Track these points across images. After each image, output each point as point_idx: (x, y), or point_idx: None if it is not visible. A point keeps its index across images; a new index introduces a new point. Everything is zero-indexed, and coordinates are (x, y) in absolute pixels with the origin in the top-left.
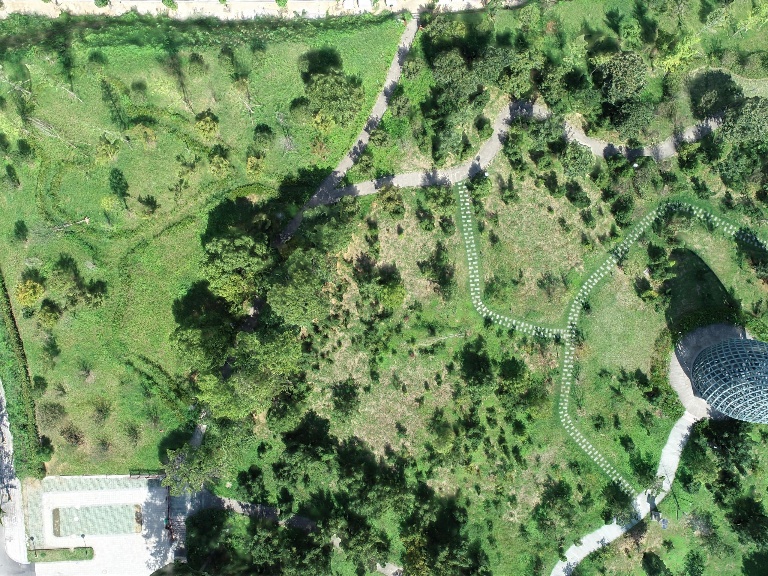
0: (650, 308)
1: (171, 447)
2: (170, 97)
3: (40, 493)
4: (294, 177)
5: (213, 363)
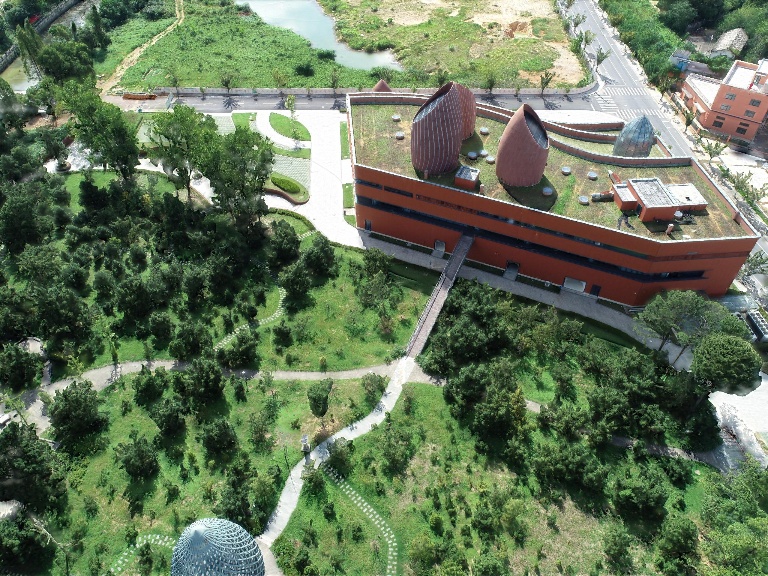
0: None
1: None
2: None
3: None
4: None
5: None
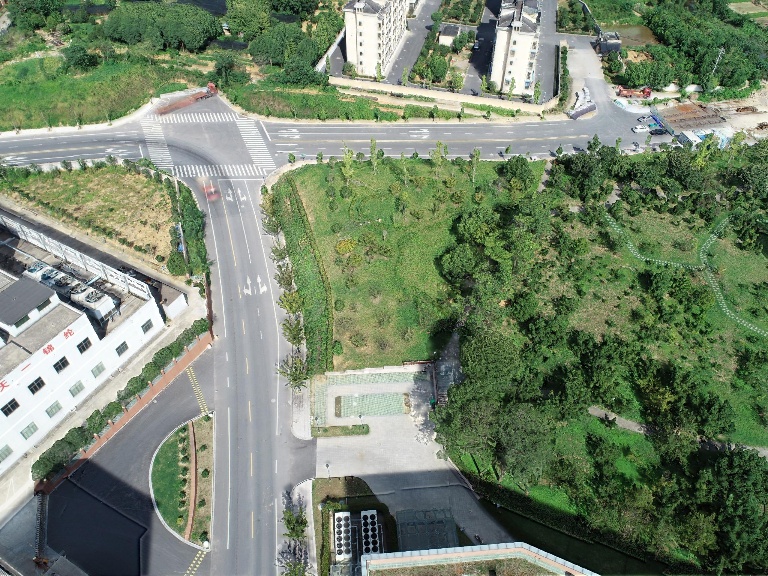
0: (752, 254)
1: (436, 343)
2: (435, 162)
3: (326, 386)
4: (500, 210)
5: (476, 265)
